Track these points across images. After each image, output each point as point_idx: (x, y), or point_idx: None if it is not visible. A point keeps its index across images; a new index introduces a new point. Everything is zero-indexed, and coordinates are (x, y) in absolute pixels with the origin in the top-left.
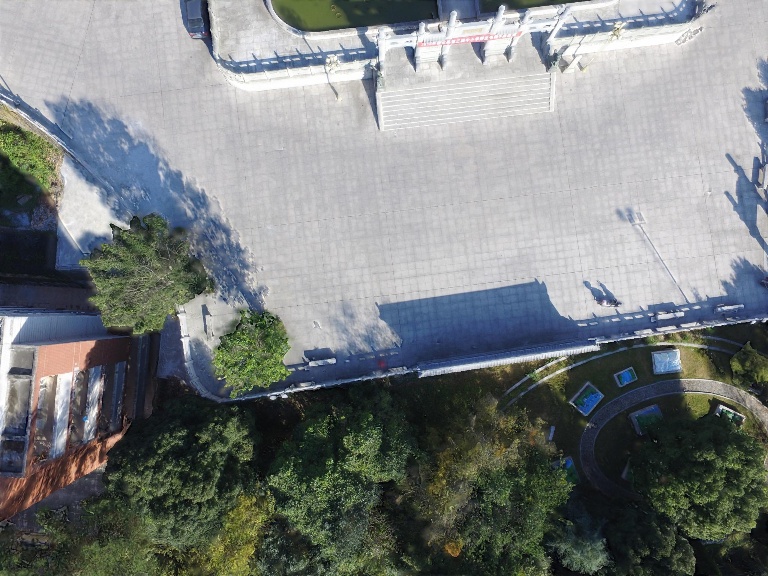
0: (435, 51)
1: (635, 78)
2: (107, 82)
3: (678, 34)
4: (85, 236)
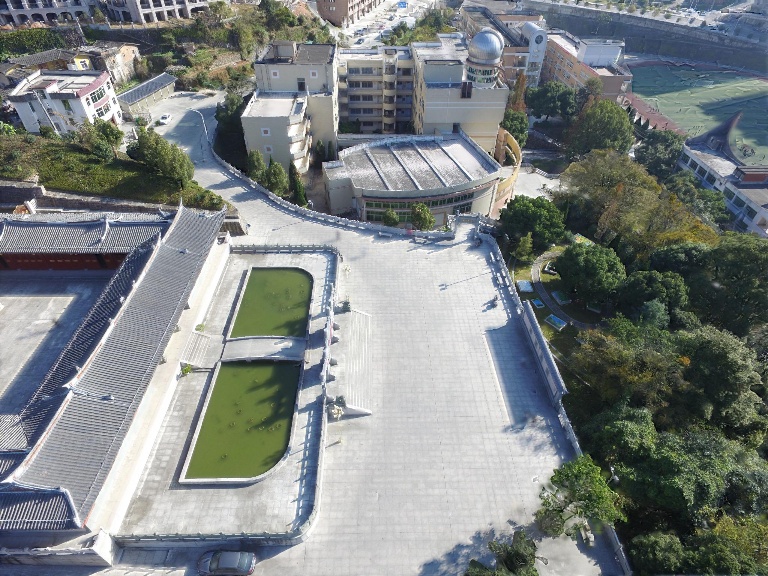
0: None
1: (358, 280)
2: None
3: None
4: None
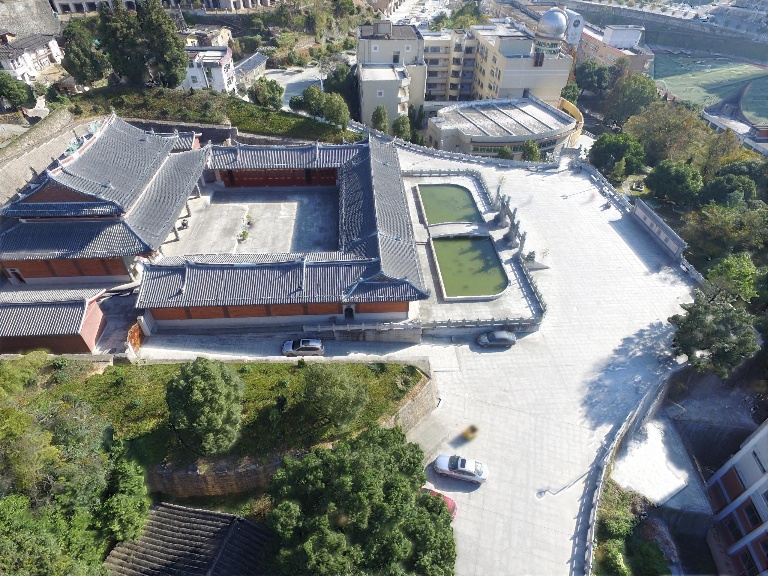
0: None
1: None
2: (559, 399)
3: None
4: (671, 480)
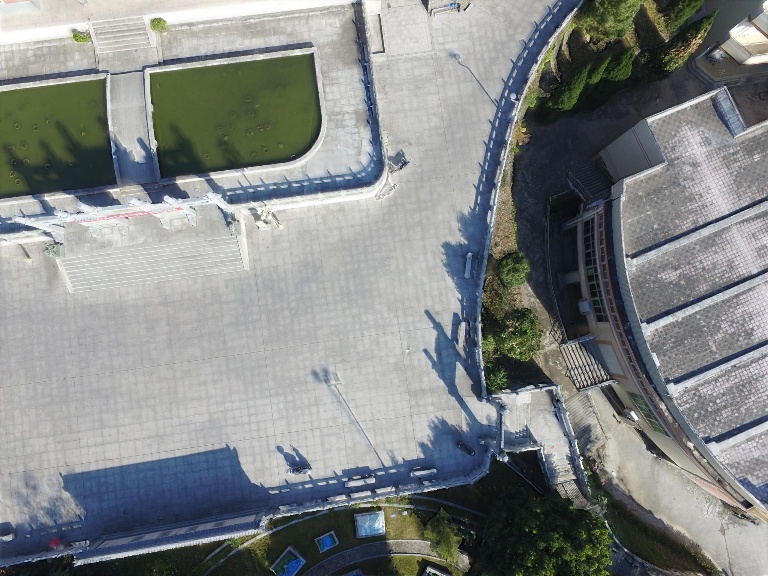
0: (106, 221)
1: (333, 234)
2: None
3: (367, 194)
4: None
